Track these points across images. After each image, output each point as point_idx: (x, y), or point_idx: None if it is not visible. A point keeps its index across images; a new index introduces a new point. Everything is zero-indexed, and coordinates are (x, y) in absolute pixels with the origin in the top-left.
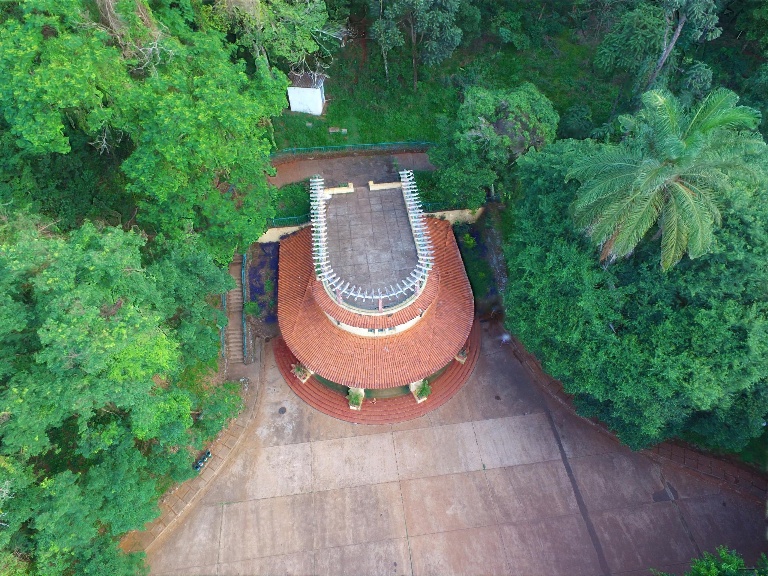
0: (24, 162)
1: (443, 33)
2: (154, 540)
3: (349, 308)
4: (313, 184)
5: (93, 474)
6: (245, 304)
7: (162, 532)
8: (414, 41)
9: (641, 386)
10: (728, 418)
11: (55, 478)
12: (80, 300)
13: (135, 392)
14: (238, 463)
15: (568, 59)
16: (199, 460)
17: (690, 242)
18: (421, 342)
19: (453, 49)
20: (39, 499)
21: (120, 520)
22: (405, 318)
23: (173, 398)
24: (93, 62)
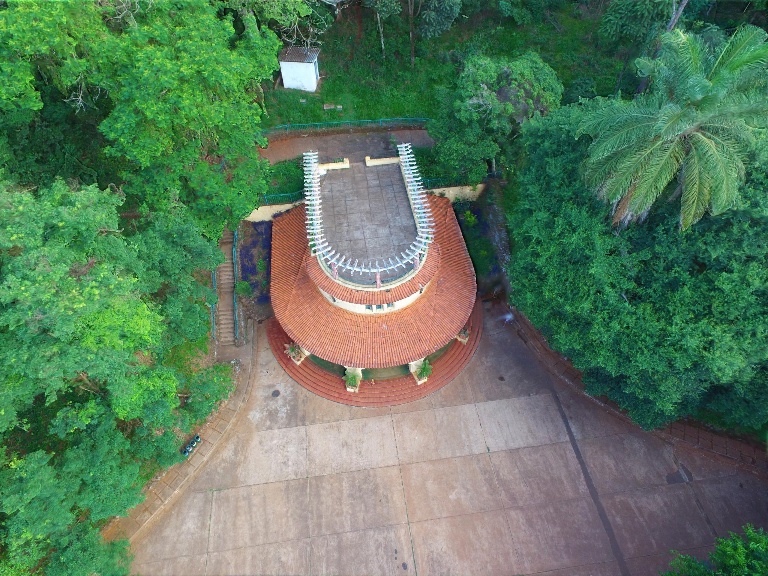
0: (0, 132)
1: (441, 3)
2: (139, 529)
3: (345, 283)
4: (307, 158)
5: (70, 456)
6: (236, 284)
7: (148, 520)
8: (411, 13)
9: (657, 357)
10: (747, 393)
11: (26, 458)
12: (47, 258)
13: (110, 360)
14: (229, 448)
15: (570, 34)
16: (187, 445)
17: (714, 195)
18: (421, 320)
19: (452, 21)
20: (11, 482)
21: (100, 505)
22: (404, 293)
23: (157, 376)
24: (64, 6)
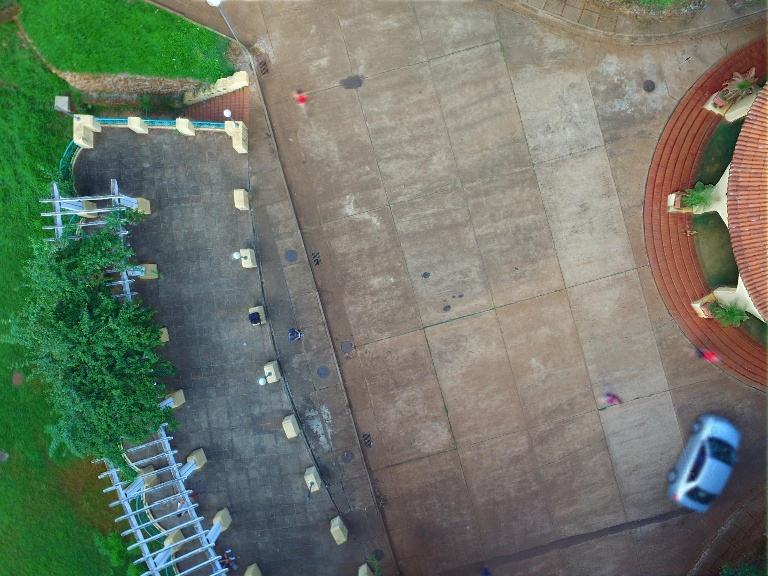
0: None
1: None
2: None
3: None
4: None
5: None
6: None
7: None
8: None
9: None
10: None
11: None
12: None
13: None
14: (559, 42)
15: None
16: None
17: None
18: None
19: None
20: None
21: None
22: None
23: None
24: None
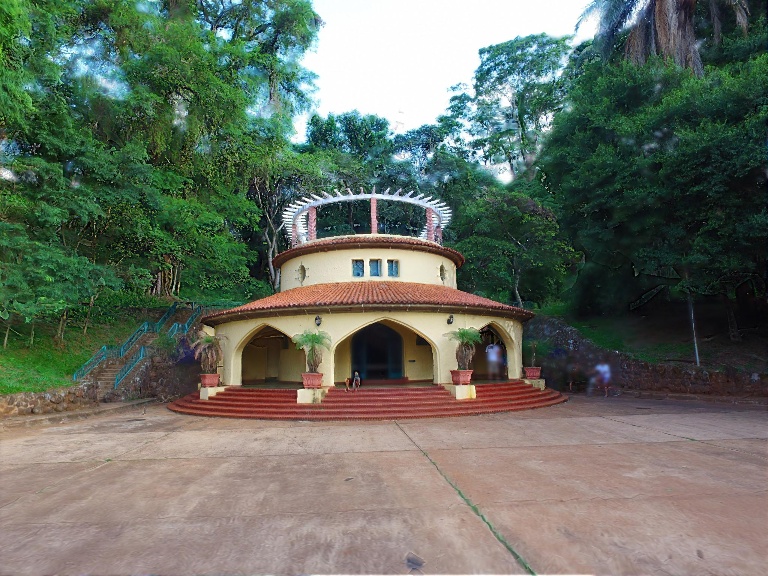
0: None
1: None
2: None
3: None
4: None
5: None
6: None
7: None
8: None
9: None
10: None
11: None
12: None
13: None
14: None
15: None
16: None
17: None
18: None
19: None
20: None
21: None
22: None
23: None
24: (135, 2)
